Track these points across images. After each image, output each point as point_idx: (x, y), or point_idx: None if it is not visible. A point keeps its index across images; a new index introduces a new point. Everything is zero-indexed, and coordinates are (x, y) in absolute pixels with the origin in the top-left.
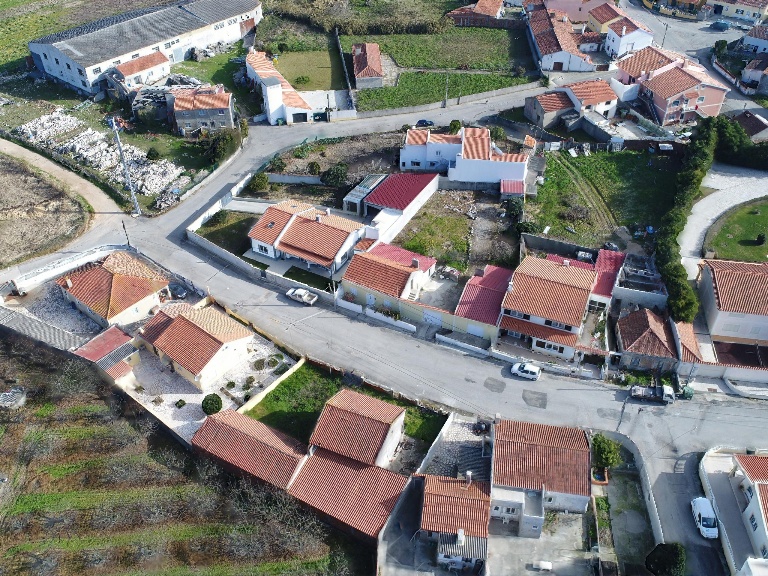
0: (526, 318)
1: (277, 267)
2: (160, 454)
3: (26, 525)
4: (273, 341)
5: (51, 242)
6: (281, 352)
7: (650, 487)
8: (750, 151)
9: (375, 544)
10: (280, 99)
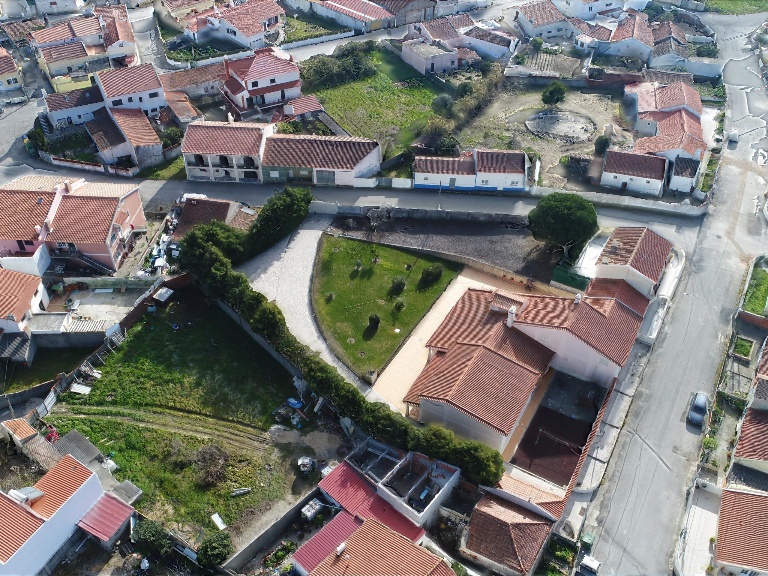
0: None
1: None
2: None
3: None
4: None
5: None
6: None
7: None
8: (251, 240)
9: None
10: None
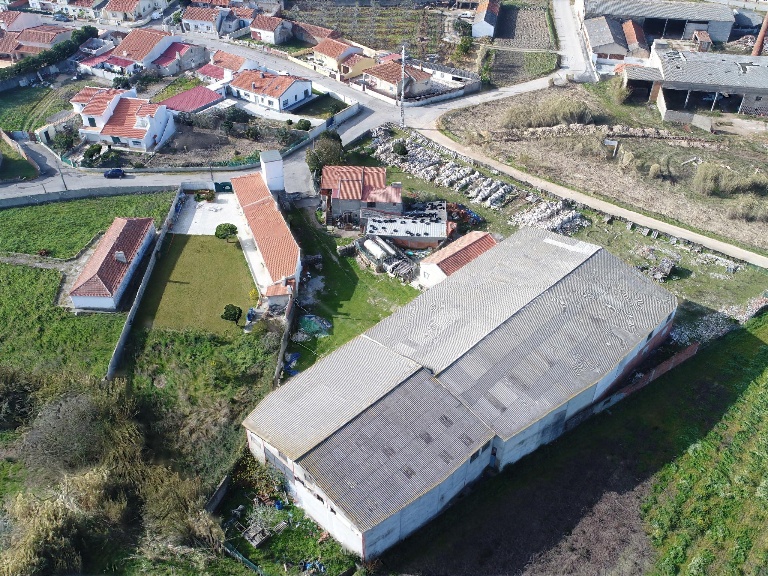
0: None
1: None
2: None
3: None
4: None
5: (459, 112)
6: None
7: None
8: None
9: None
10: None
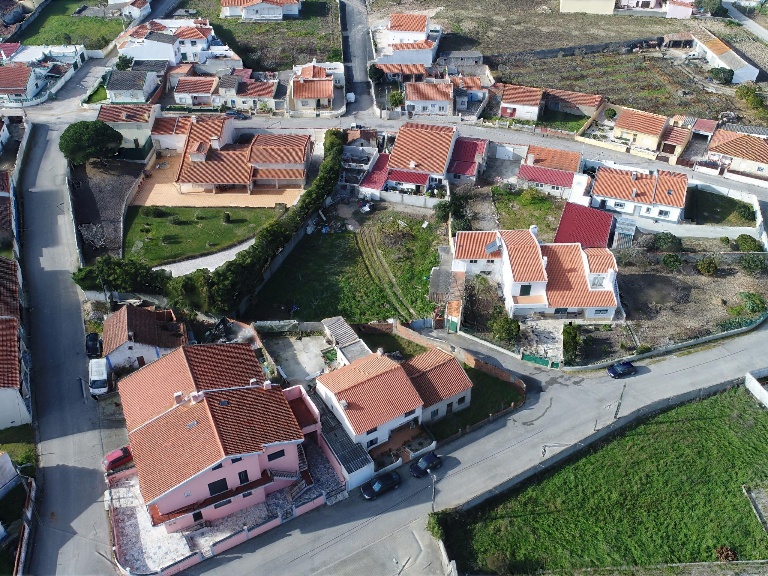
0: None
1: None
2: None
3: None
4: None
5: None
6: None
7: None
8: None
9: None
10: None
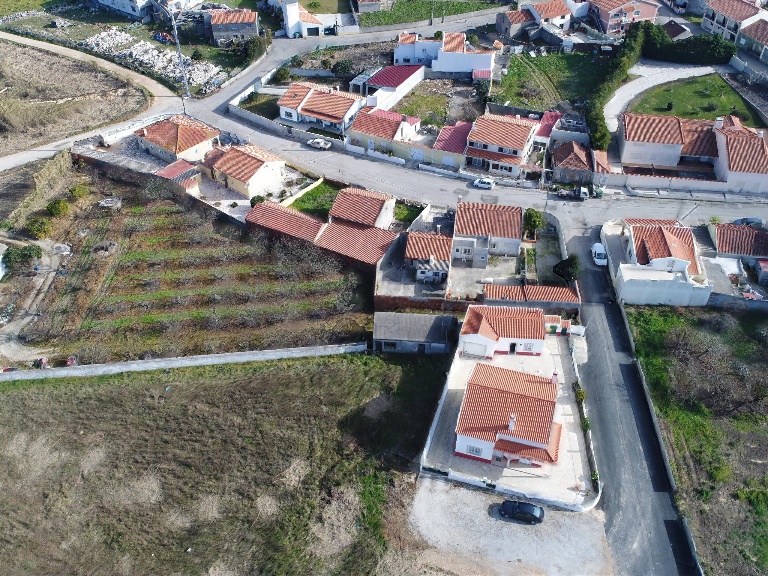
0: (485, 148)
1: (300, 128)
2: (222, 232)
3: (135, 265)
4: (299, 170)
5: (124, 114)
6: (305, 177)
7: (563, 238)
8: (670, 47)
9: (375, 270)
10: (297, 16)
